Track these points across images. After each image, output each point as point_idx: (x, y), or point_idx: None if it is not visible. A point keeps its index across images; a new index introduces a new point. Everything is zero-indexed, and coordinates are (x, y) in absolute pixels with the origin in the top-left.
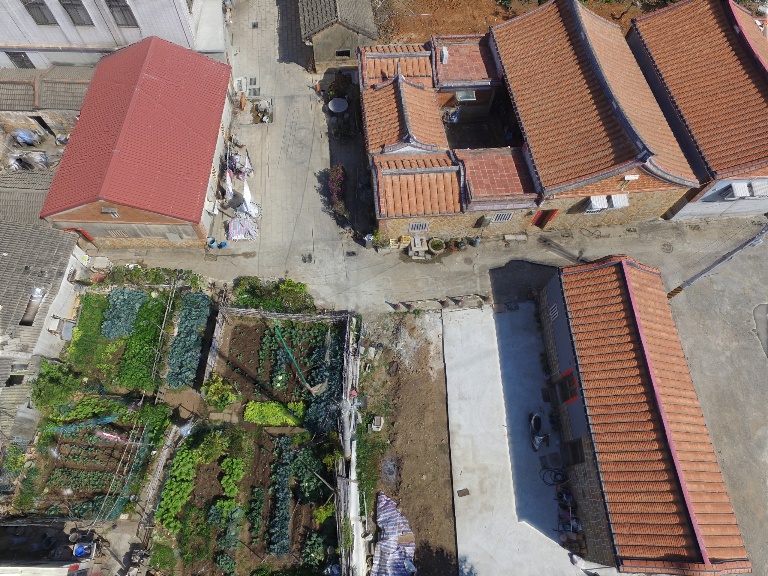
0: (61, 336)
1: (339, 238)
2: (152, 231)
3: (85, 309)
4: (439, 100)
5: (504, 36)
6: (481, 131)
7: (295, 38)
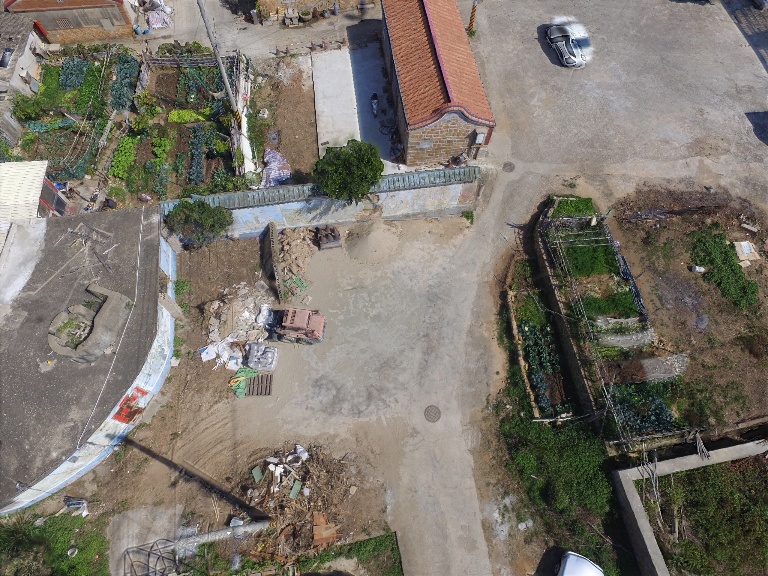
0: (30, 86)
1: (234, 21)
2: (89, 17)
3: (46, 75)
4: None
5: None
6: None
7: None
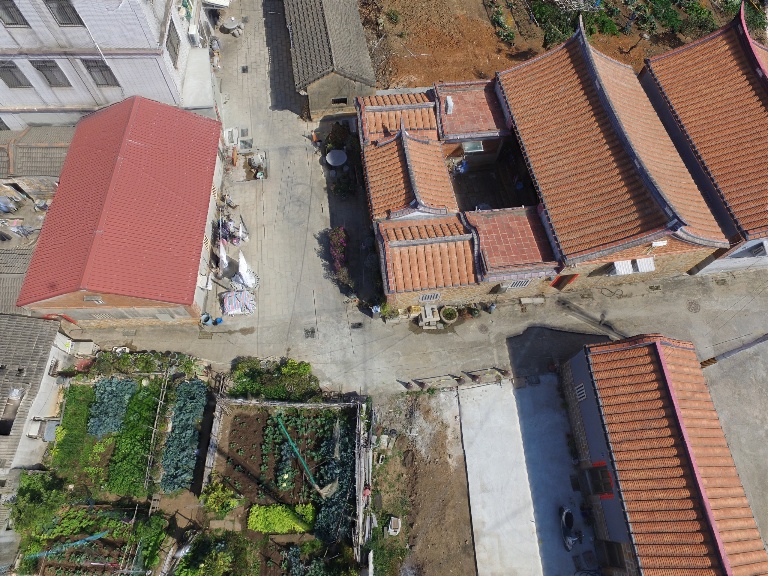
0: (43, 438)
1: (343, 308)
2: (141, 313)
3: (69, 403)
4: (444, 151)
5: (512, 83)
6: (489, 180)
7: (288, 82)
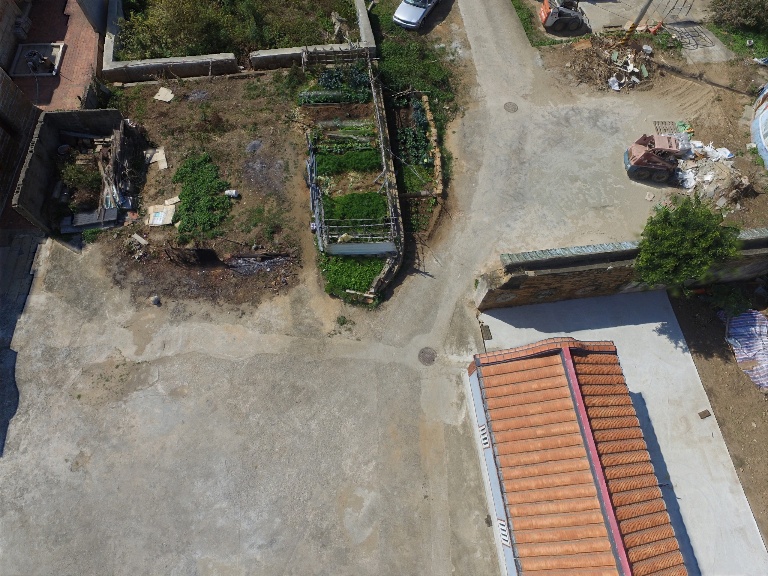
0: None
1: None
2: None
3: None
4: None
5: None
6: None
7: None
